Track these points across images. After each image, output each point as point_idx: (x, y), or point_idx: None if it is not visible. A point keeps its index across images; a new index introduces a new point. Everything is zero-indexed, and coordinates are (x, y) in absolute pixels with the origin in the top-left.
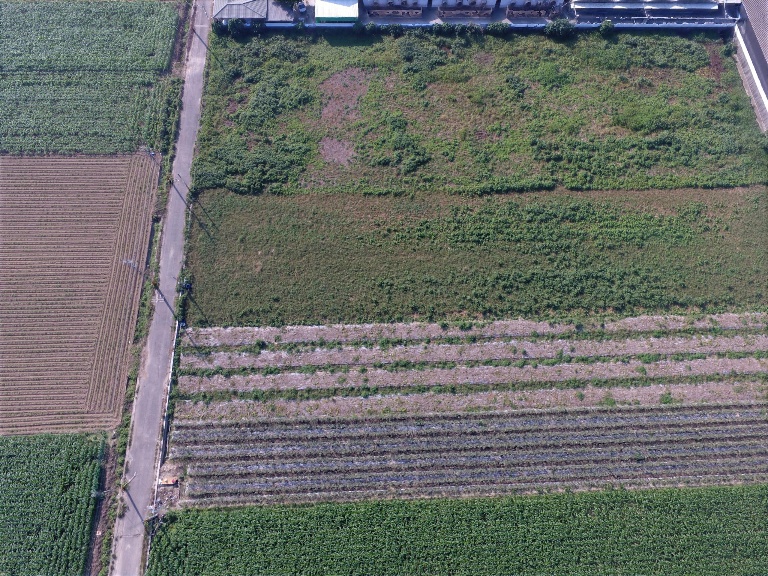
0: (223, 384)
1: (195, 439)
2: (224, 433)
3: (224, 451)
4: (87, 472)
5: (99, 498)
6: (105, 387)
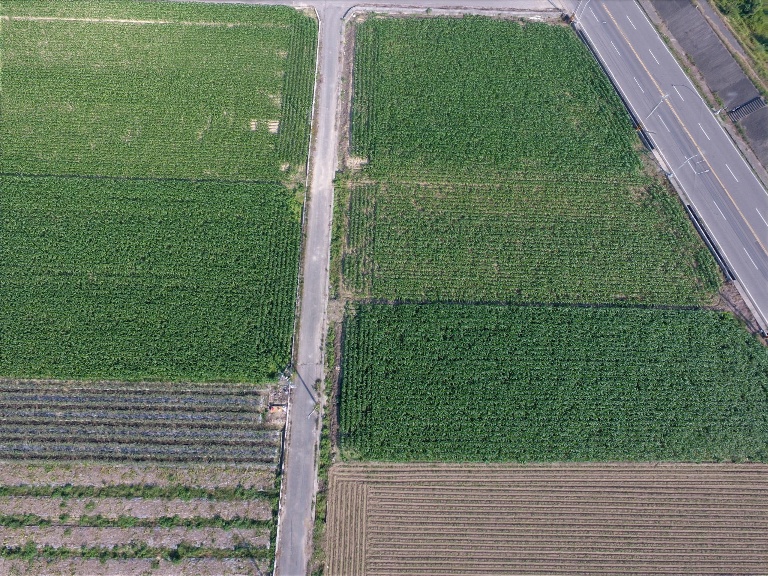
0: (223, 508)
1: (253, 448)
2: (224, 453)
3: (225, 435)
4: (351, 422)
5: (340, 398)
6: (349, 511)
